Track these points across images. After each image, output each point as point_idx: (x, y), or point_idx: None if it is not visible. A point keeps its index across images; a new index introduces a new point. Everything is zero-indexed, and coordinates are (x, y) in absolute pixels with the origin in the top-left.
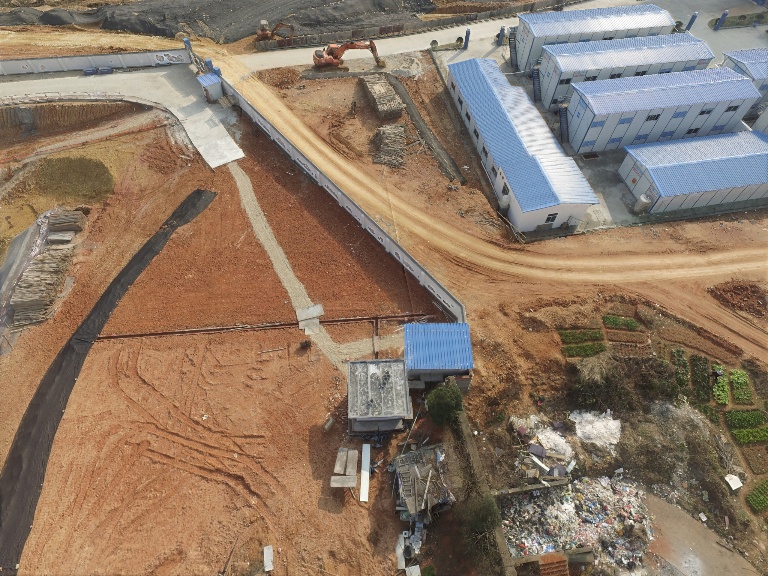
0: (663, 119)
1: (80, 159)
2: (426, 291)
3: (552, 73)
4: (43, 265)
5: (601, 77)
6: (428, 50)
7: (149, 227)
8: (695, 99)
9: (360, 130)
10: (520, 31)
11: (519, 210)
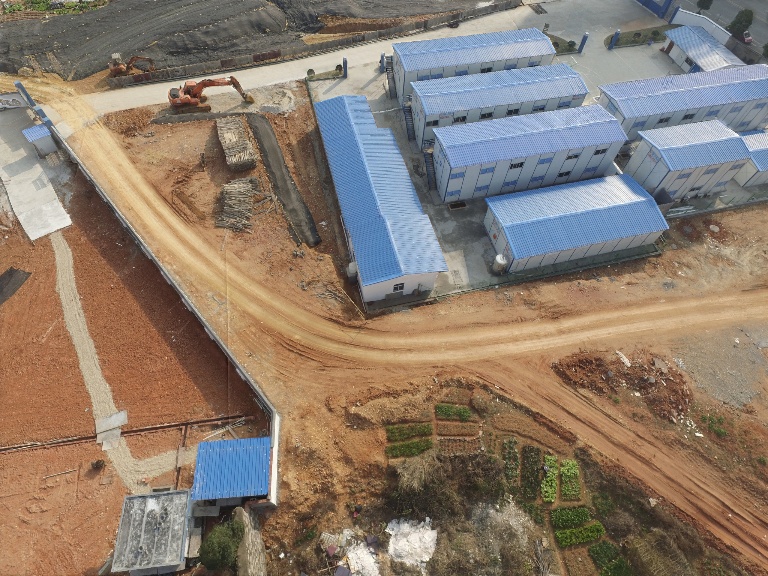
0: (528, 166)
1: None
2: (248, 386)
3: (419, 113)
4: None
5: (471, 117)
6: (305, 80)
7: None
8: (559, 145)
9: (207, 186)
10: (395, 62)
11: (361, 282)
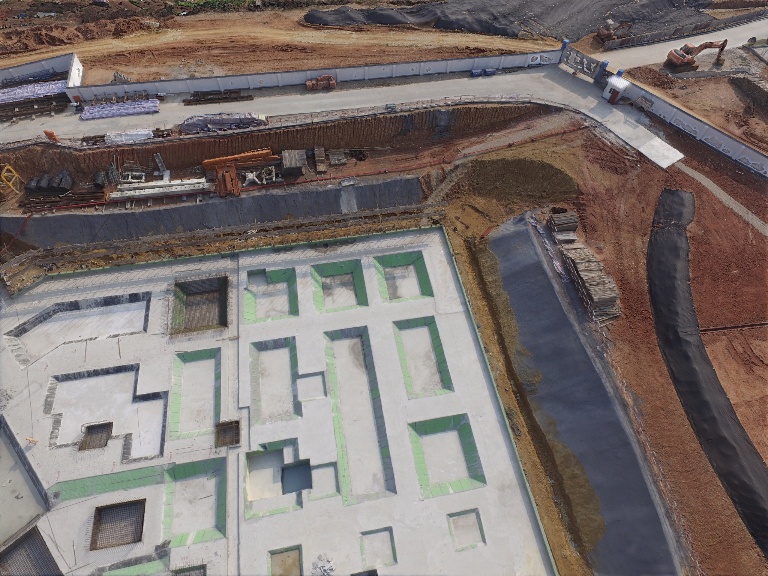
0: None
1: (519, 161)
2: None
3: None
4: (588, 264)
5: None
6: (745, 47)
7: (639, 226)
8: None
9: None
10: None
11: None
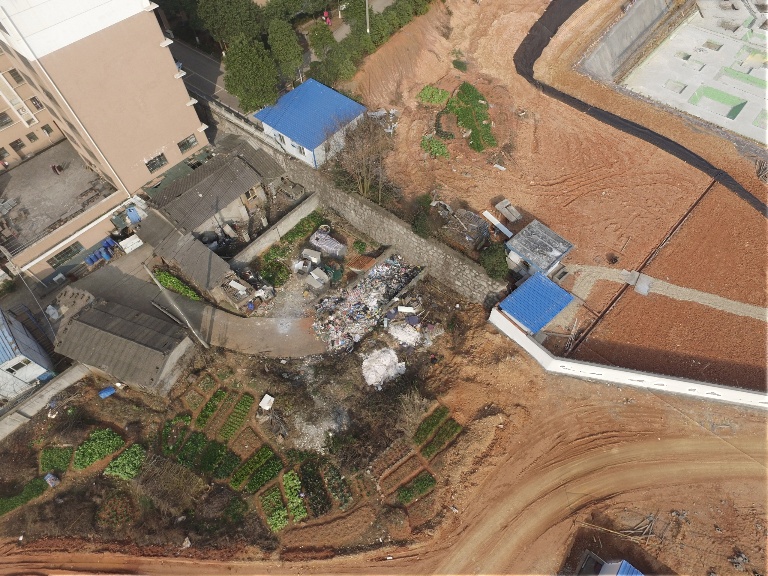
0: None
1: None
2: None
3: None
4: None
5: None
6: None
7: None
8: None
9: None
10: None
11: None
